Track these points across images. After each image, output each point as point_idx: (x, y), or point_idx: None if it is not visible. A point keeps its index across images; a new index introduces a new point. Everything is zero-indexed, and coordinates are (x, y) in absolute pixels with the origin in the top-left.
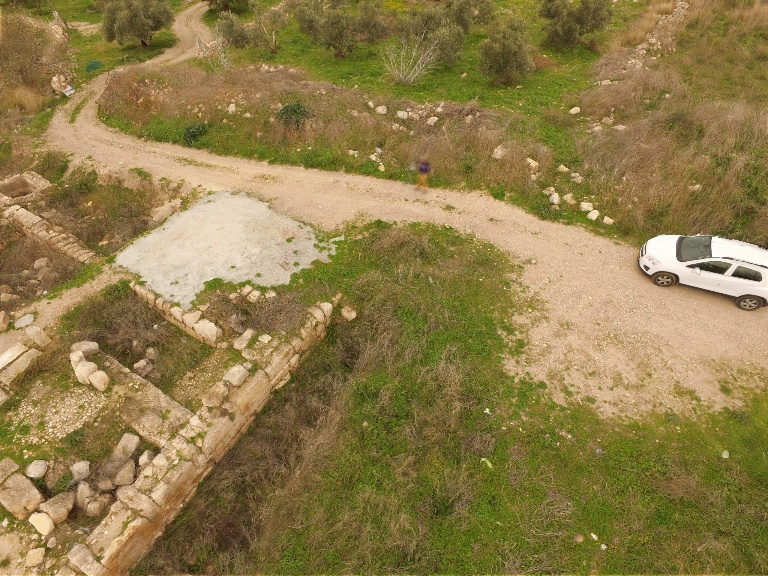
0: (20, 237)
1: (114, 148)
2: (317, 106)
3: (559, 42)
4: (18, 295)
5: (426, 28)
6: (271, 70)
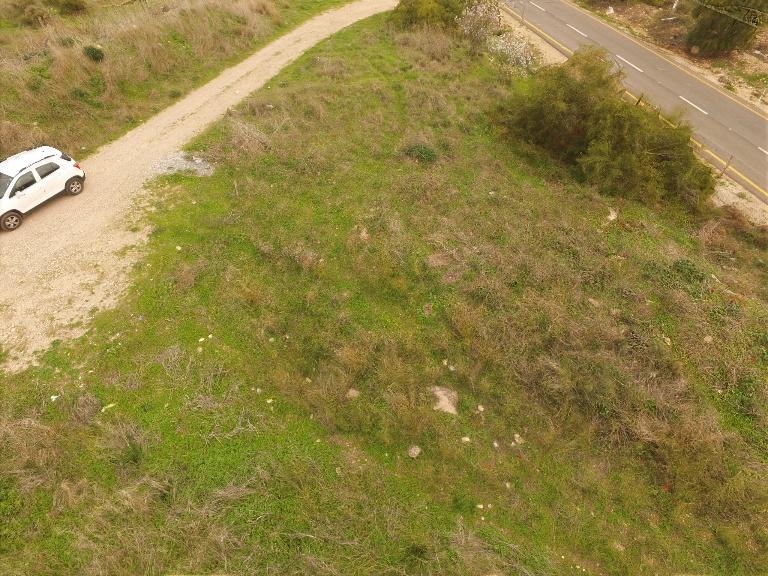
0: None
1: None
2: None
3: None
4: None
5: None
6: None
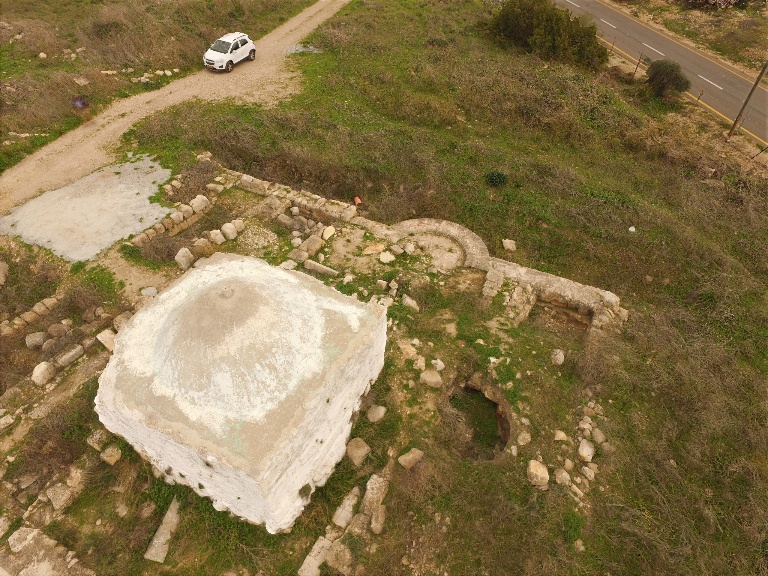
0: None
1: None
2: None
3: None
4: None
5: None
6: None
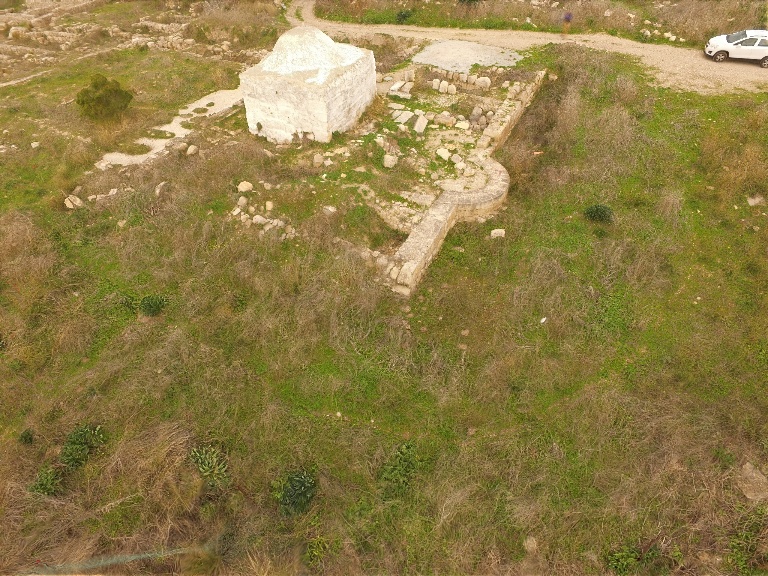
0: None
1: (350, 28)
2: None
3: None
4: None
5: None
6: None
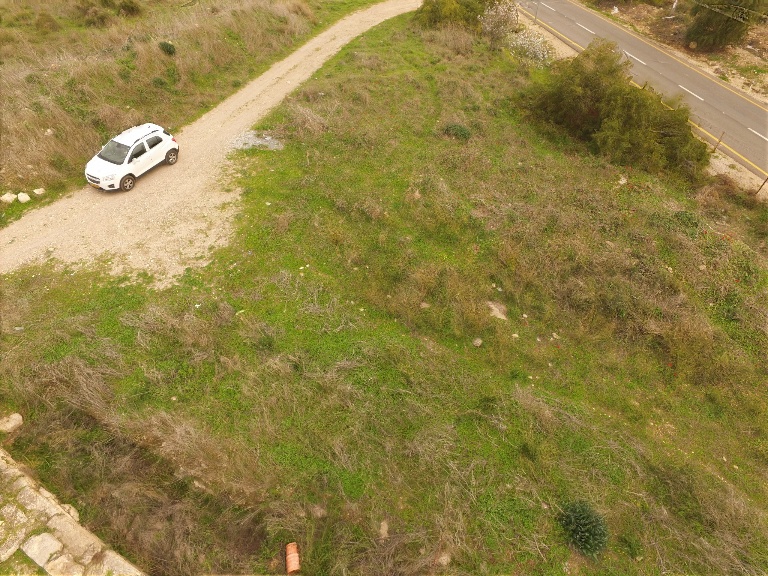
0: None
1: None
2: None
3: None
4: None
5: None
6: None
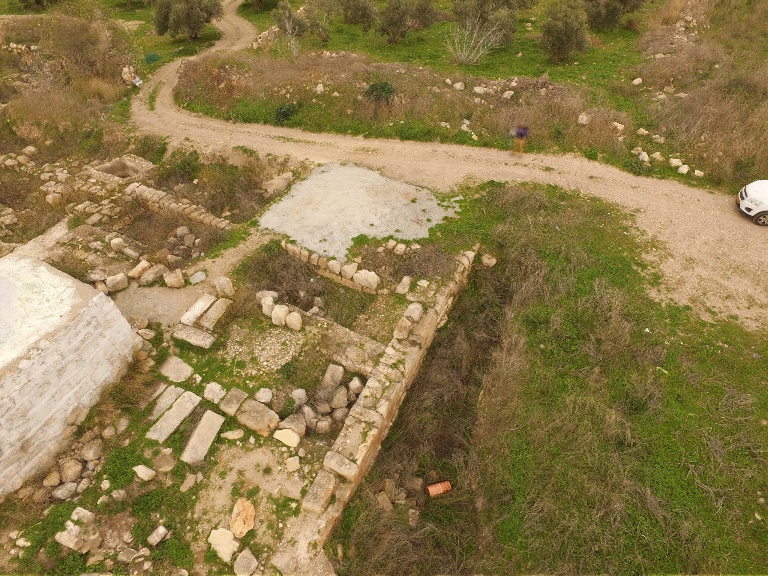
0: (144, 212)
1: (207, 130)
2: (400, 84)
3: (599, 23)
4: (180, 257)
5: (481, 11)
6: (334, 56)
